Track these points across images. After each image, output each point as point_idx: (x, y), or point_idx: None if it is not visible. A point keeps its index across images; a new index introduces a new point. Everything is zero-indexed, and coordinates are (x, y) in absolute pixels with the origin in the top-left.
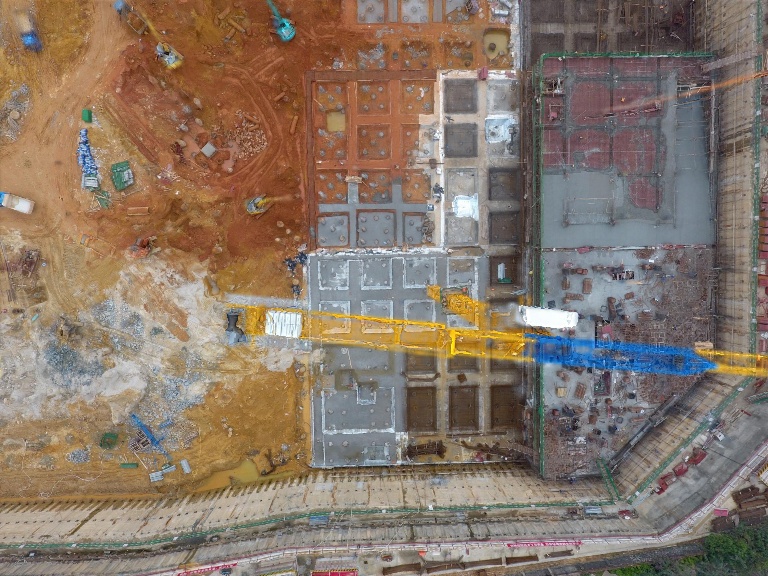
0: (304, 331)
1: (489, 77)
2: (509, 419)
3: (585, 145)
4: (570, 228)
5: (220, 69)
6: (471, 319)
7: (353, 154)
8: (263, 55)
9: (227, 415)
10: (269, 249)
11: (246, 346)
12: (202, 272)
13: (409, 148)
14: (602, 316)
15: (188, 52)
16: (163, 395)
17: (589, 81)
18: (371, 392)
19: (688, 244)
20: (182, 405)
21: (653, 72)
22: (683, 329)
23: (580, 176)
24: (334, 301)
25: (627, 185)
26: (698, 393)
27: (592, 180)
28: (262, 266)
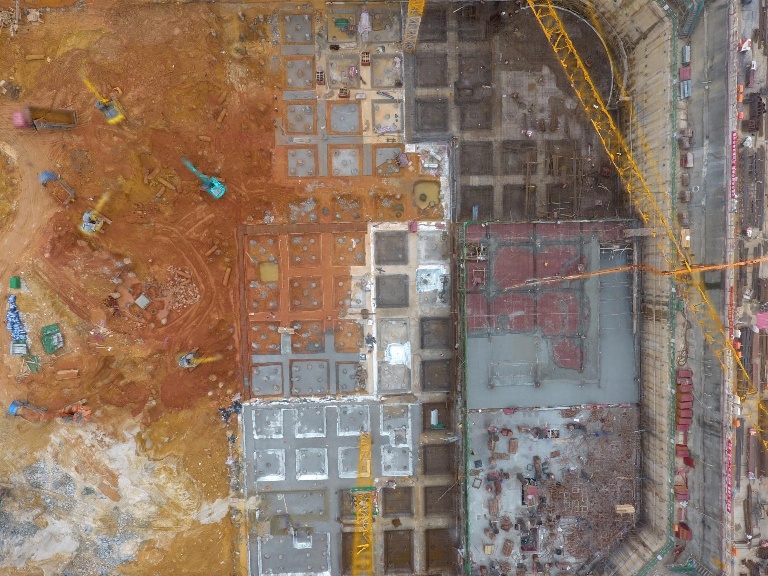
0: (240, 478)
1: (420, 229)
2: (444, 560)
3: (509, 308)
4: (495, 389)
5: (151, 227)
6: (406, 463)
7: (285, 306)
8: (193, 213)
9: (160, 570)
10: (203, 400)
11: (178, 504)
12: (134, 429)
13: (342, 298)
14: (528, 474)
15: (117, 215)
16: (95, 554)
17: (512, 246)
18: (308, 535)
19: (613, 403)
20: (115, 561)
21: (576, 236)
22: (609, 486)
23: (505, 339)
24: (269, 449)
25: (551, 346)
26: (622, 551)
27: (517, 342)
28: (196, 417)
